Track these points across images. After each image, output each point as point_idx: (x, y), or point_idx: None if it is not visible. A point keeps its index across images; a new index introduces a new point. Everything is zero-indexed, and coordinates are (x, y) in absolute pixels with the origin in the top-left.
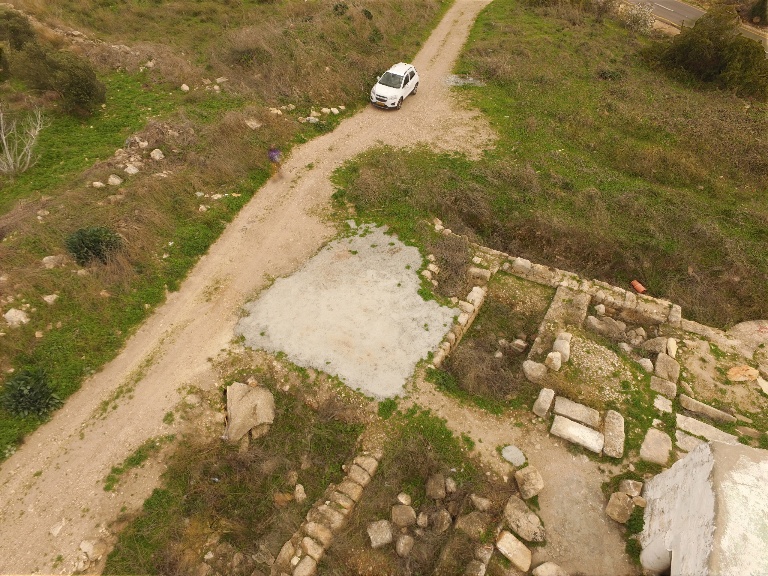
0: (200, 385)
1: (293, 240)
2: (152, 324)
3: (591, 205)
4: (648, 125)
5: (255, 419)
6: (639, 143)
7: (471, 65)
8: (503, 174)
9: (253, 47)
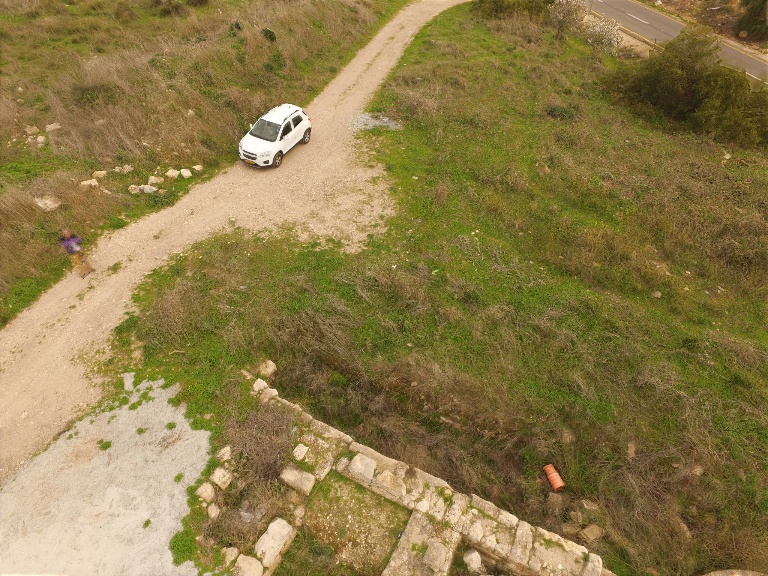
0: None
1: (26, 416)
2: None
3: (498, 331)
4: (597, 189)
5: None
6: (583, 216)
7: (390, 99)
8: (379, 282)
9: (104, 82)
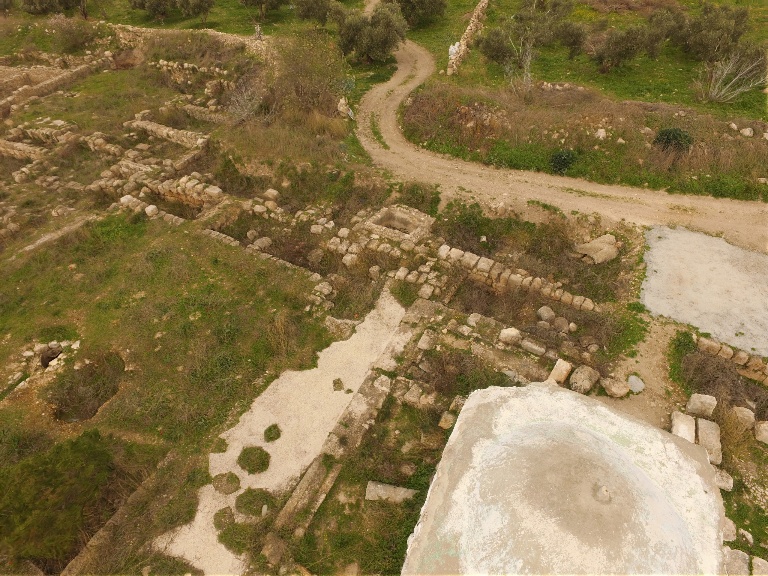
0: (603, 221)
1: None
2: (634, 191)
3: None
4: None
5: None
6: None
7: None
8: None
9: None
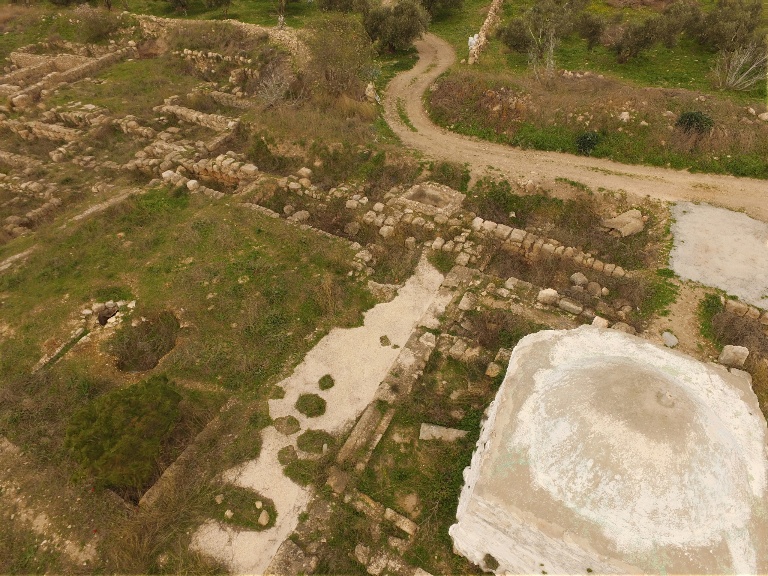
0: (629, 197)
1: None
2: (657, 170)
3: None
4: None
5: (621, 227)
6: None
7: None
8: None
9: None
